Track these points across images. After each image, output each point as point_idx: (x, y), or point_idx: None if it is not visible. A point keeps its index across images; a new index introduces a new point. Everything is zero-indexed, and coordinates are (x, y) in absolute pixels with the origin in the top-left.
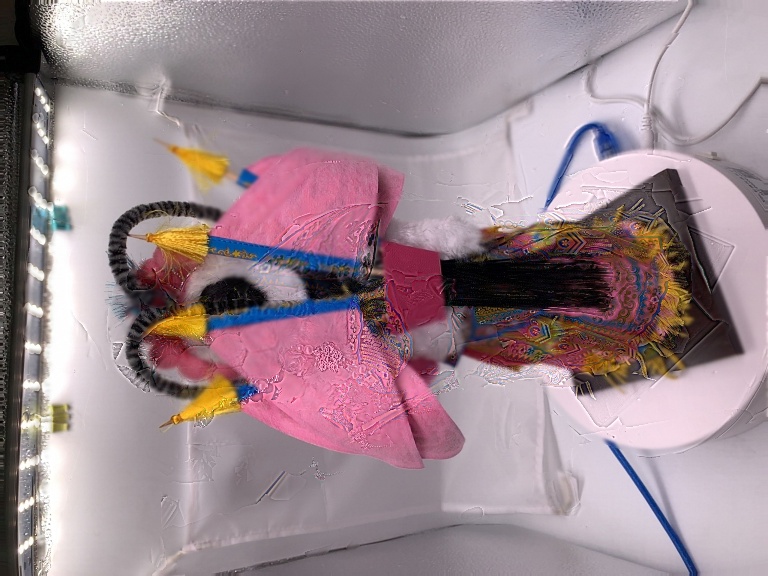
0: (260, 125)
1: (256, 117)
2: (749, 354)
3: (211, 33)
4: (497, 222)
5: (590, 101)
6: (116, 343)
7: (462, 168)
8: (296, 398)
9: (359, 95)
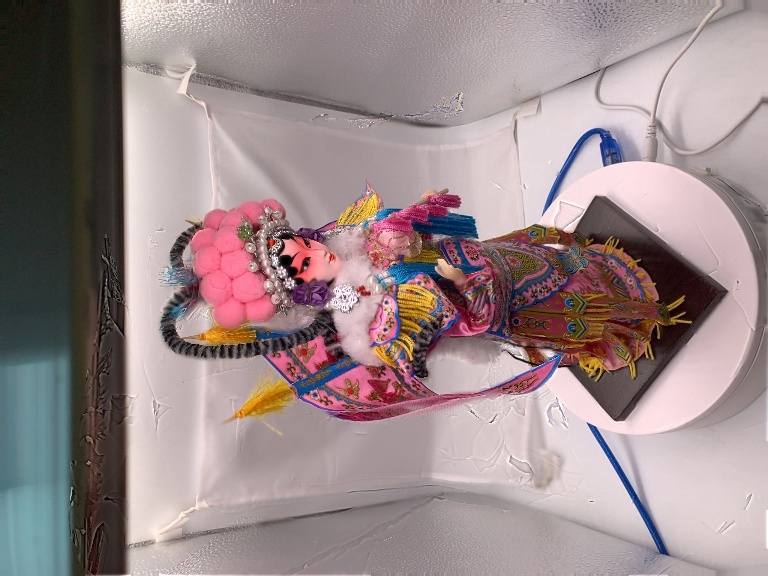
0: (307, 574)
1: (300, 574)
2: (625, 170)
3: (230, 551)
4: (338, 142)
5: (527, 399)
6: (162, 320)
7: (501, 483)
8: (334, 256)
9: (373, 504)
